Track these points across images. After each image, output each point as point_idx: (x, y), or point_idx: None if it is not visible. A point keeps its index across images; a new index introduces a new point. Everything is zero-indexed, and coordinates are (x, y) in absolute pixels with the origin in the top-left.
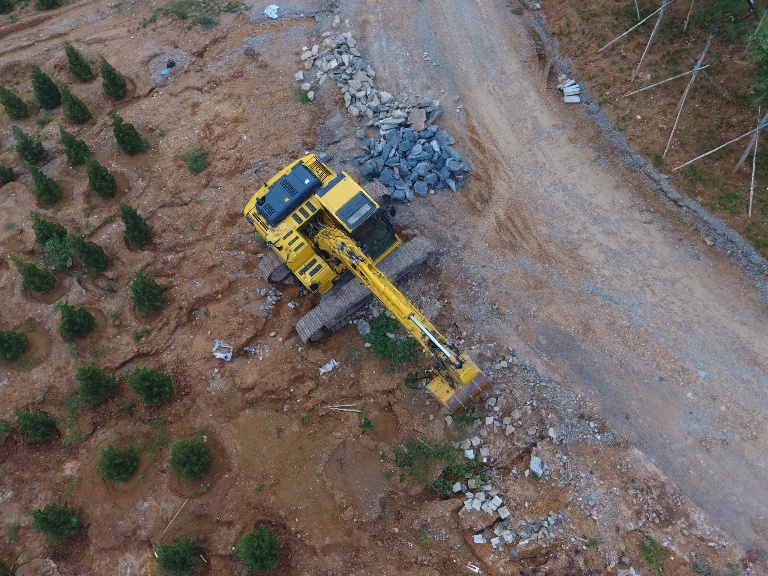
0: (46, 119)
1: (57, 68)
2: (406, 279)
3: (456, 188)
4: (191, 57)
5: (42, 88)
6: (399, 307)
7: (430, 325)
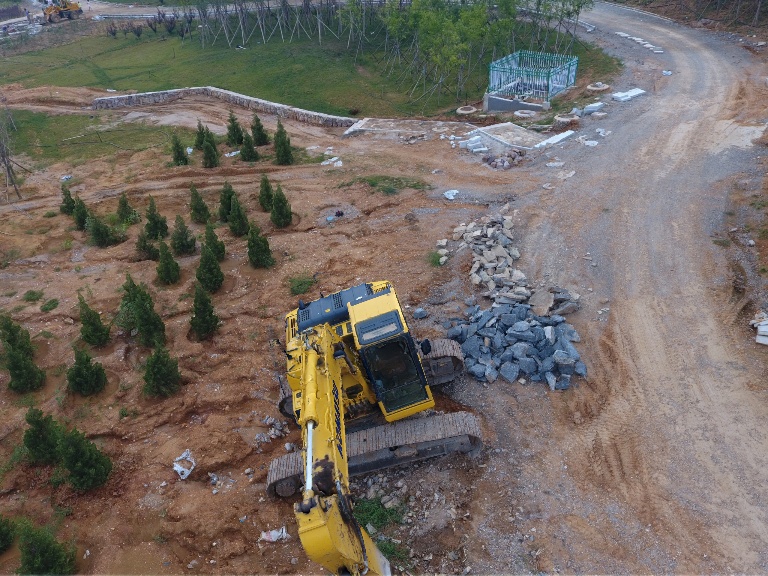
0: (214, 226)
1: (252, 197)
2: (430, 464)
3: (556, 387)
4: (360, 213)
5: (226, 202)
6: (305, 407)
7: (332, 450)
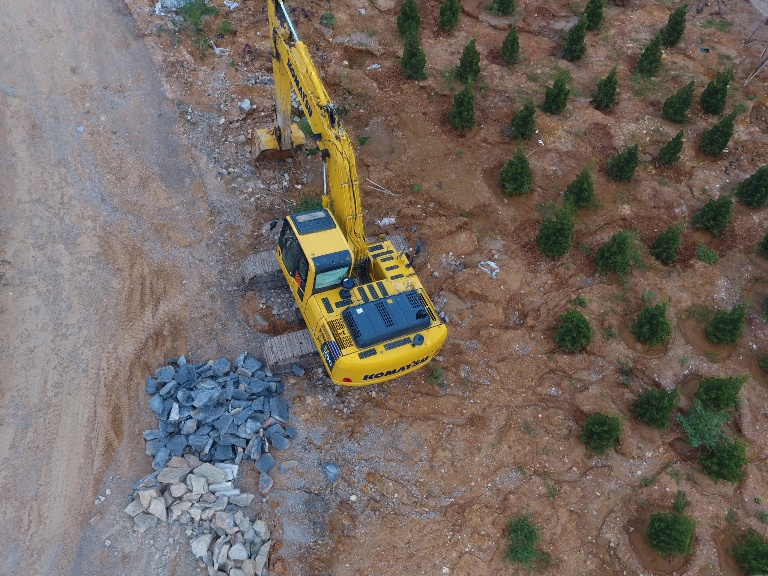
0: None
1: None
2: None
3: None
4: None
5: None
6: None
7: None
